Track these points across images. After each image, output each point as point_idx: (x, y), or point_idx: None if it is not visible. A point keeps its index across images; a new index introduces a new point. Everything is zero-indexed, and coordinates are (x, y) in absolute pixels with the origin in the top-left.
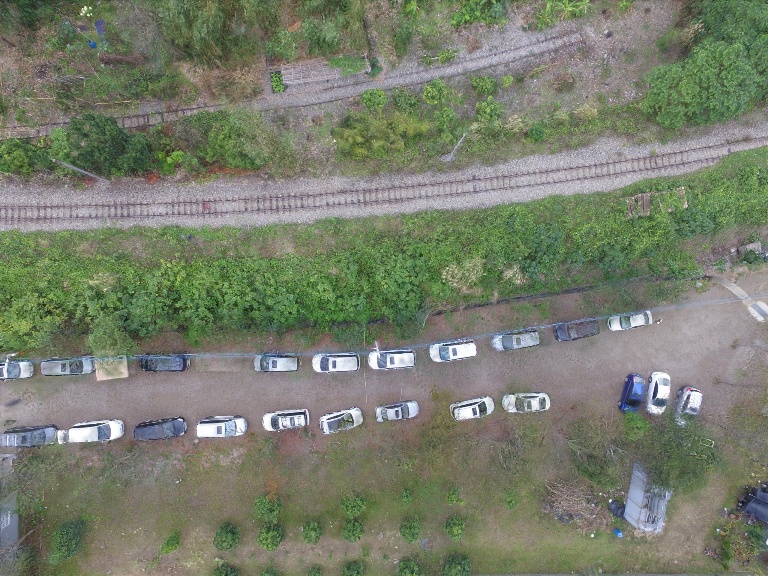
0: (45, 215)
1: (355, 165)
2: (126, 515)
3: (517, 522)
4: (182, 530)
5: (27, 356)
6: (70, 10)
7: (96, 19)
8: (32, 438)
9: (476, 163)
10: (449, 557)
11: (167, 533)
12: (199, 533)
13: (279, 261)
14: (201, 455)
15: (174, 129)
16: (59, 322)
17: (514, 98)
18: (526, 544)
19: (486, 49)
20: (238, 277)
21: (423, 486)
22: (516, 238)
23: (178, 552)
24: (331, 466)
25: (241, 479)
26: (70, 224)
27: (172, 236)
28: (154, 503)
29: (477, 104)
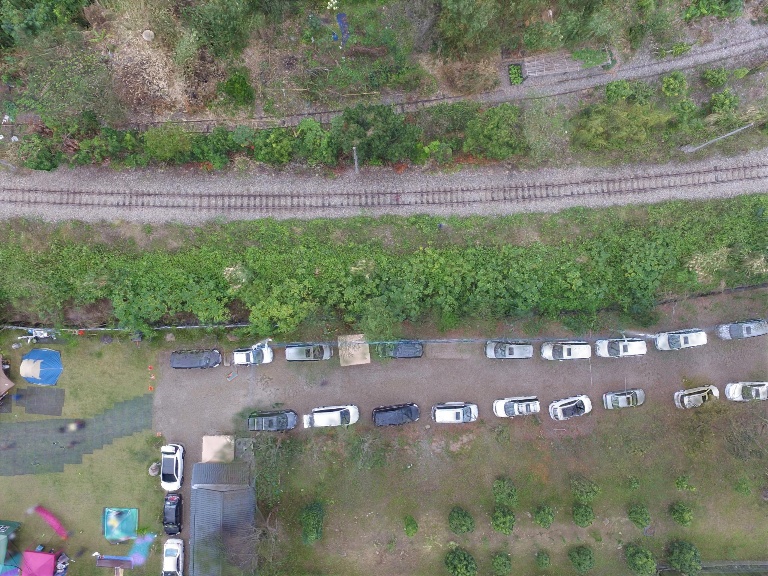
0: (298, 203)
1: (593, 156)
2: (359, 499)
3: (737, 509)
4: (412, 514)
5: None
6: (311, 4)
7: (337, 12)
8: (277, 422)
9: (716, 154)
10: (672, 543)
11: (398, 517)
12: (429, 517)
13: (526, 249)
14: (431, 441)
15: (415, 120)
16: (314, 308)
17: (739, 91)
18: (745, 531)
19: (717, 42)
20: (493, 265)
21: (646, 473)
22: (766, 227)
23: None
24: (557, 452)
25: (469, 465)
26: (323, 212)
27: (424, 224)
28: (386, 487)
29: (714, 96)
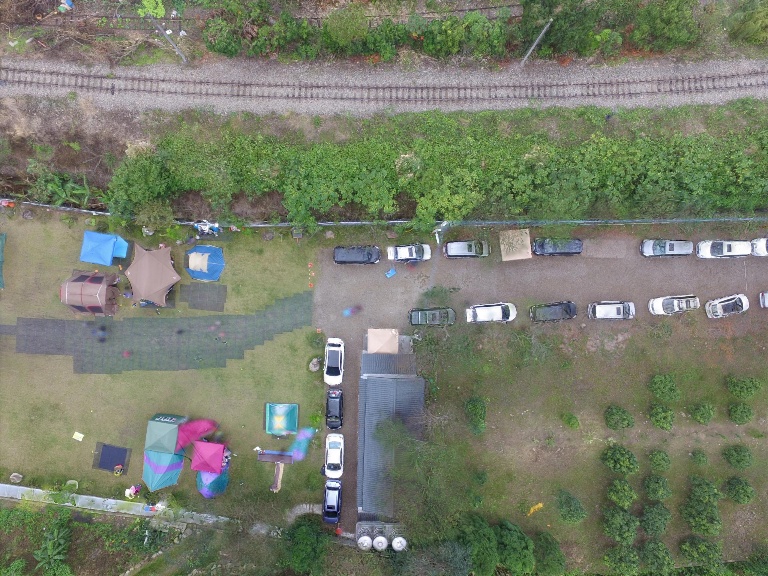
0: (465, 96)
1: (756, 50)
2: (514, 397)
3: None
4: None
5: (422, 240)
6: None
7: None
8: (440, 316)
9: None
10: None
11: (553, 415)
12: (583, 416)
13: None
14: (586, 339)
15: None
16: (483, 199)
17: None
18: None
19: None
20: (664, 153)
21: None
22: None
23: (568, 433)
24: (711, 352)
25: (624, 364)
26: (490, 104)
27: None
28: (541, 386)
29: None
